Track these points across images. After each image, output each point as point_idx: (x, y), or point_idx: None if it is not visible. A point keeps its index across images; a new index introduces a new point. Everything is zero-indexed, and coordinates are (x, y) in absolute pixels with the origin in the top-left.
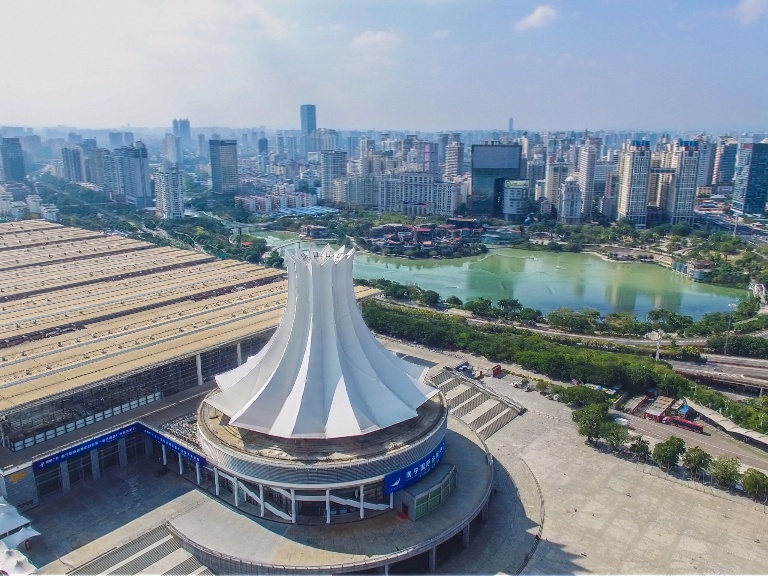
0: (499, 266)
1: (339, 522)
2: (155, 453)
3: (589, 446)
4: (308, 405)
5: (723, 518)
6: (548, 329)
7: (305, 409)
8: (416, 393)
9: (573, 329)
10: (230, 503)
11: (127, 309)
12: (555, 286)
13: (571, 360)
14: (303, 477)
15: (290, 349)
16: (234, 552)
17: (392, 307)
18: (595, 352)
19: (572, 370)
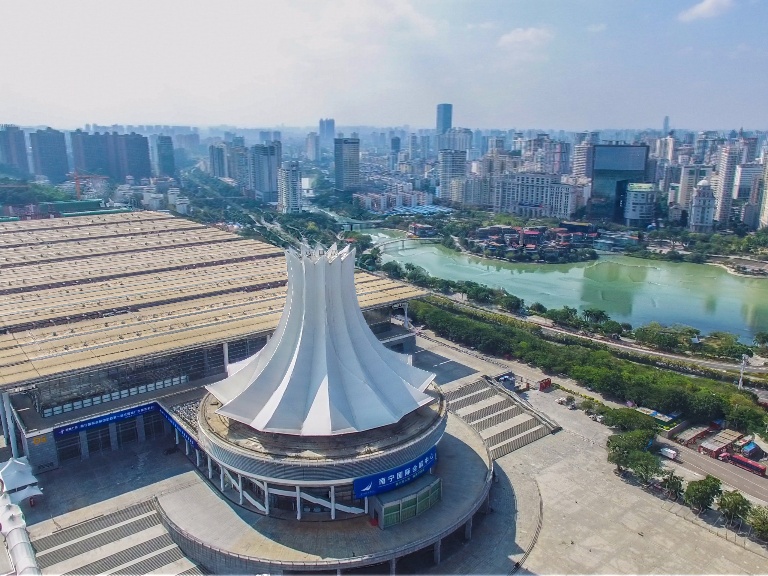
0: (617, 274)
1: (309, 520)
2: (173, 432)
3: (617, 475)
4: (289, 401)
5: (746, 575)
6: (632, 345)
7: (285, 404)
8: (408, 399)
9: (660, 347)
10: (218, 487)
11: (182, 296)
12: (661, 299)
13: (629, 380)
14: (271, 471)
15: (283, 344)
16: (201, 534)
17: (468, 310)
18: (668, 373)
19: (627, 391)
